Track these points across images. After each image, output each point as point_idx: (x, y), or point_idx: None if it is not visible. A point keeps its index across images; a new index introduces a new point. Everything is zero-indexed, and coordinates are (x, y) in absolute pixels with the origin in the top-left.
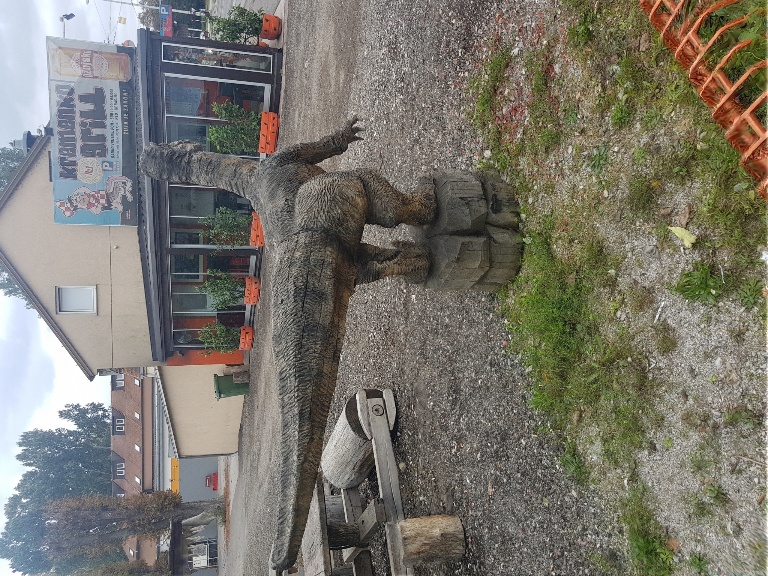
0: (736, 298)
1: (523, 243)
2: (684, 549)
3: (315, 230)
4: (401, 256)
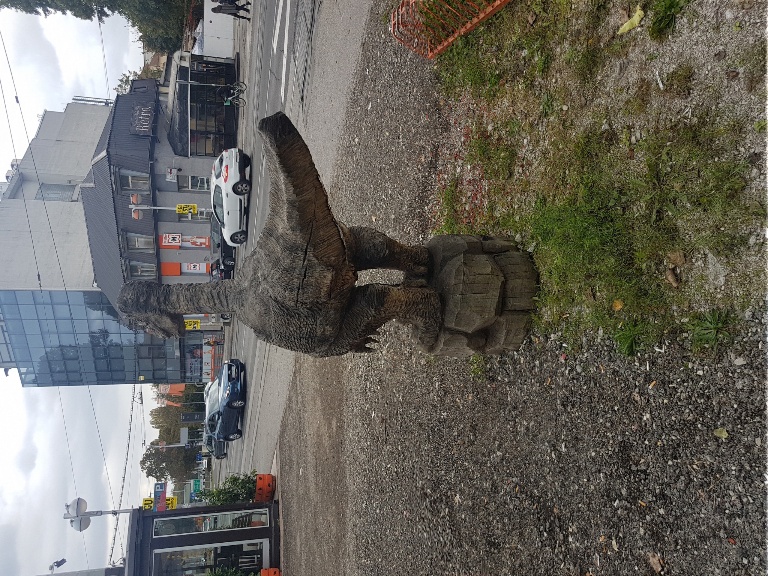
0: None
1: (529, 254)
2: None
3: None
4: (404, 285)
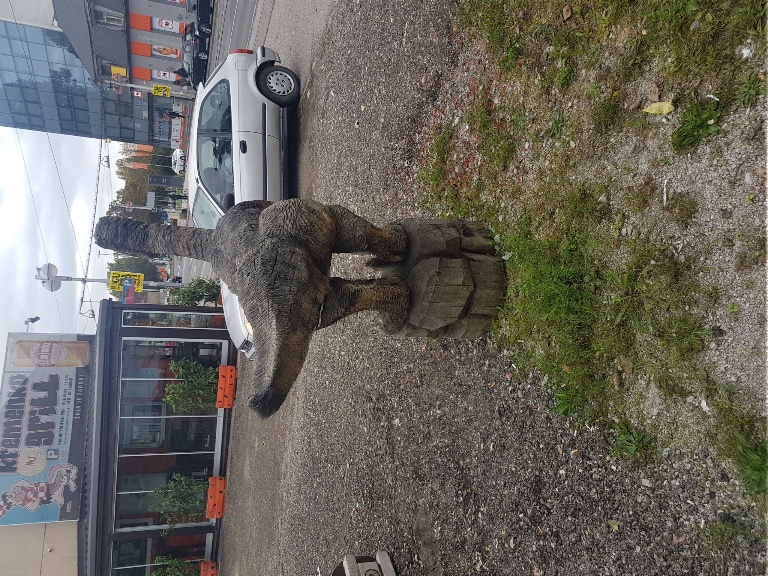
0: (736, 107)
1: (503, 261)
2: None
3: (282, 236)
4: (377, 283)
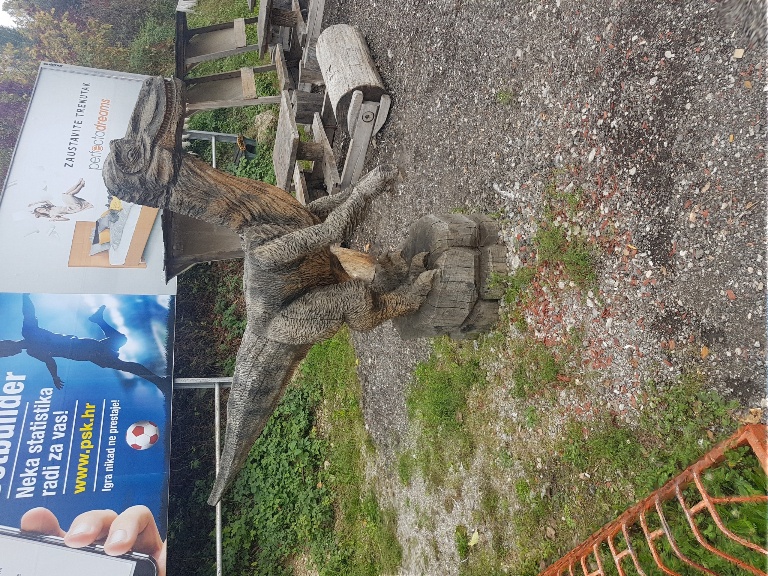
0: None
1: None
2: (409, 493)
3: (283, 344)
4: None
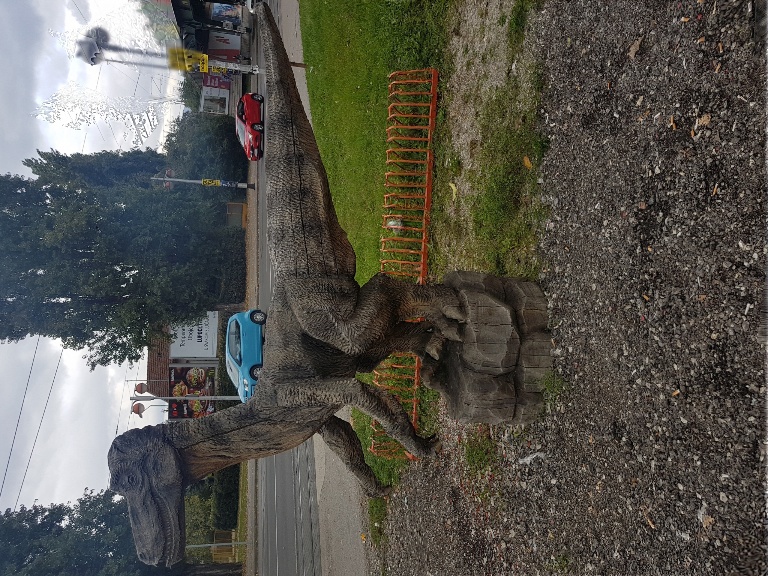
0: None
1: None
2: None
3: None
4: None
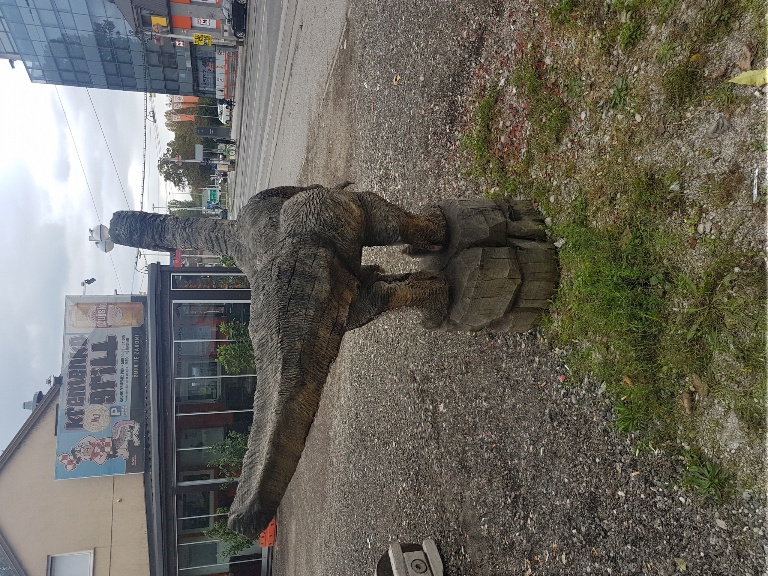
0: None
1: (555, 248)
2: None
3: (304, 234)
4: (413, 277)
